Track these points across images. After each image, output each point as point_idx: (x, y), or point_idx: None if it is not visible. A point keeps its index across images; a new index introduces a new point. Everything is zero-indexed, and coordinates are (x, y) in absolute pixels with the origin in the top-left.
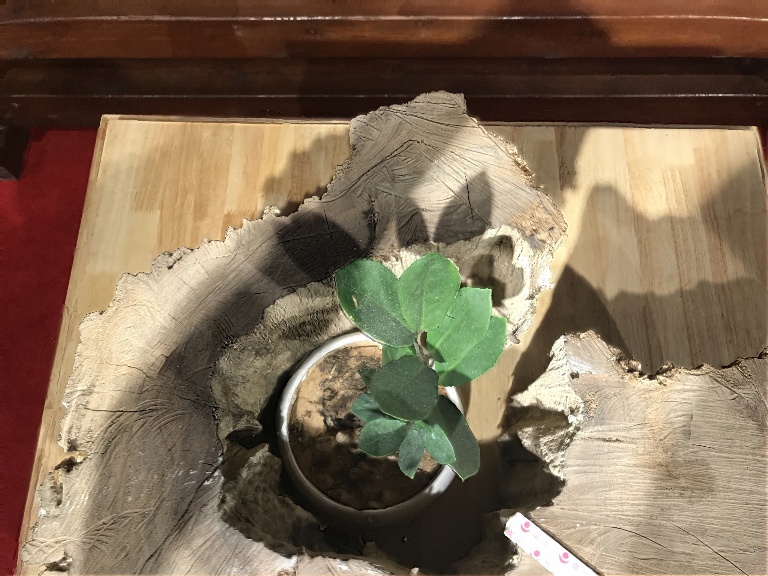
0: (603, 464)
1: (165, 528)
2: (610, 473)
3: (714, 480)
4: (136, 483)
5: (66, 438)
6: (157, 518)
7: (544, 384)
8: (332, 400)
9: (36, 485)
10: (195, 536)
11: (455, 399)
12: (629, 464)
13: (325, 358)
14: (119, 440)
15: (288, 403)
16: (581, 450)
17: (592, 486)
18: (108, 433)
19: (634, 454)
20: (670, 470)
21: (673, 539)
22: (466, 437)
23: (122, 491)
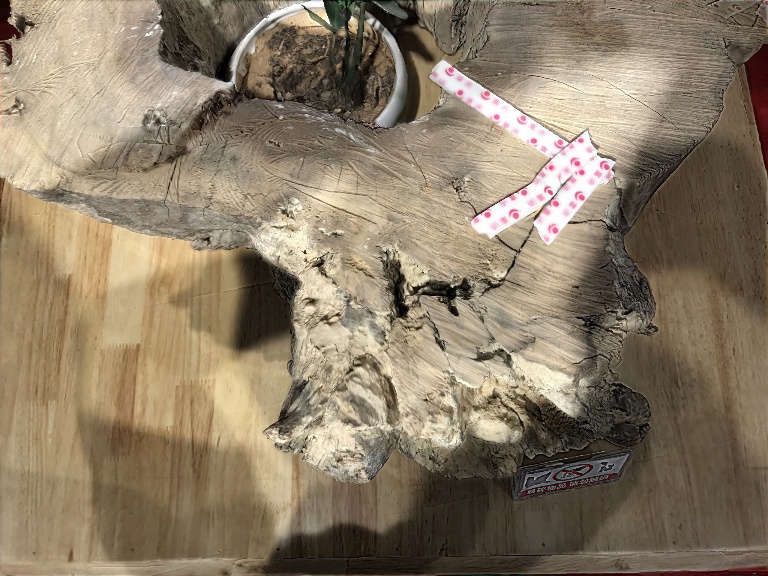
0: (523, 24)
1: (110, 72)
2: (530, 31)
3: (627, 37)
4: (81, 42)
5: (13, 12)
6: (102, 65)
7: (475, 0)
8: (282, 74)
9: (3, 188)
10: (138, 74)
11: (397, 50)
12: (548, 24)
13: (273, 34)
14: (63, 11)
15: (236, 60)
16: (503, 12)
17: (513, 41)
18: (53, 6)
19: (553, 15)
20: (586, 28)
21: (588, 84)
22: (395, 8)
23: (68, 49)
